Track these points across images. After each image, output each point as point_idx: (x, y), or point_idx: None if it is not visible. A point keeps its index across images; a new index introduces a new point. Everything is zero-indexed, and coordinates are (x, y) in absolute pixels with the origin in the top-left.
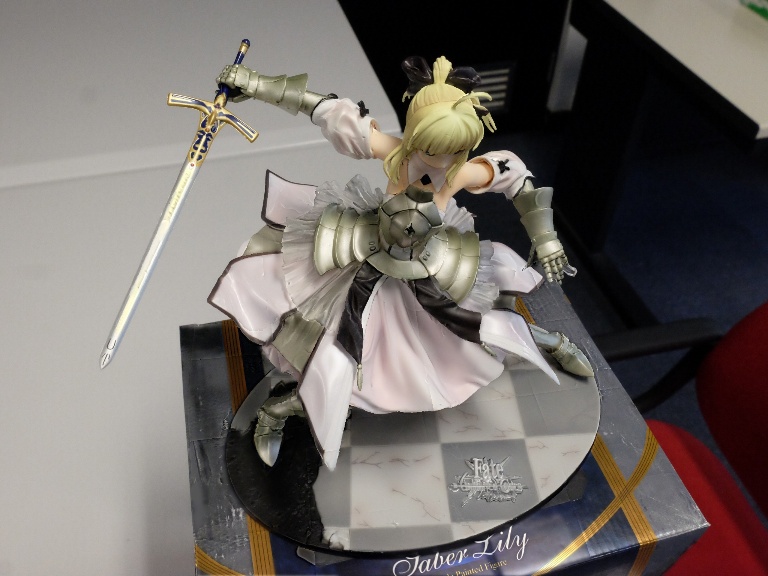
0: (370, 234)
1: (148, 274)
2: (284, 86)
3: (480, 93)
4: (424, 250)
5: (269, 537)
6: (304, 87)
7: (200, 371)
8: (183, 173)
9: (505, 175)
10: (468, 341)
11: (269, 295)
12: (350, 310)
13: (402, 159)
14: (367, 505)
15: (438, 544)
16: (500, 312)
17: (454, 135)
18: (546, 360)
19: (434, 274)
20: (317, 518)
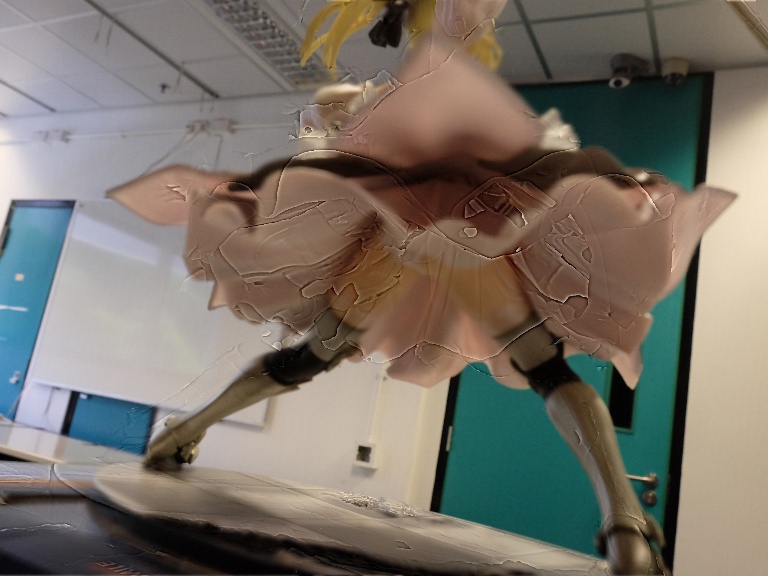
0: None
1: None
2: None
3: None
4: None
5: None
6: None
7: None
8: None
9: None
10: (386, 299)
11: None
12: None
13: None
14: None
15: None
16: None
17: None
18: None
19: None
20: None
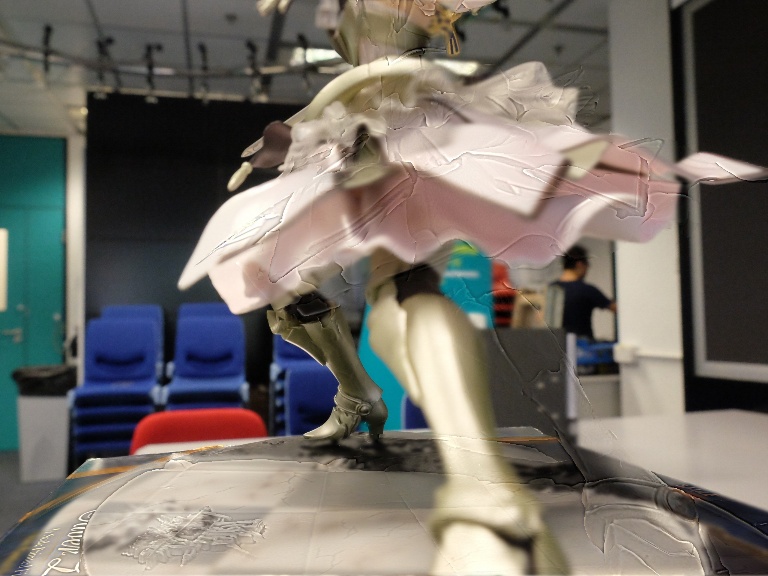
0: None
1: None
2: None
3: None
4: None
5: None
6: None
7: (461, 431)
8: None
9: None
10: None
11: None
12: None
13: None
14: (215, 477)
15: (101, 505)
16: None
17: None
18: (328, 242)
19: None
20: None
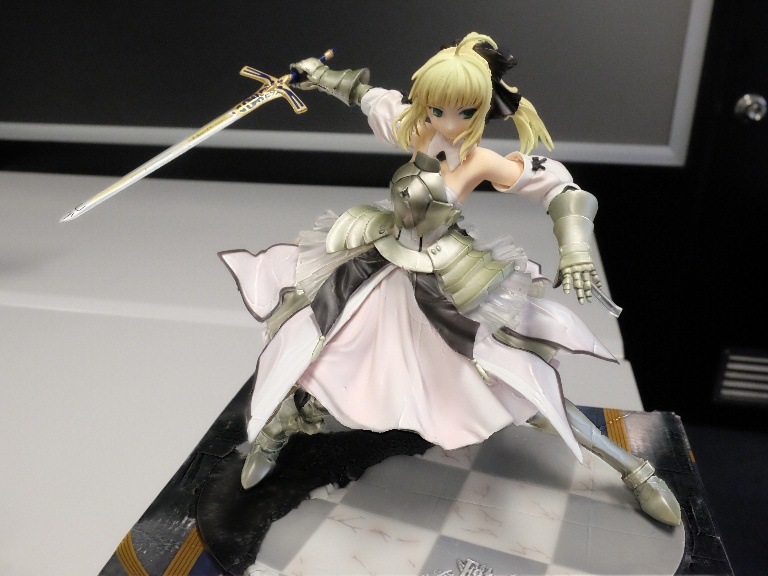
0: (386, 220)
1: (146, 172)
2: (343, 74)
3: (481, 35)
4: (435, 243)
5: (200, 554)
6: (357, 73)
7: (246, 404)
8: (222, 116)
9: (539, 175)
10: (470, 369)
11: (282, 273)
12: (335, 282)
13: (412, 120)
14: (315, 560)
15: None
16: (523, 352)
17: (450, 78)
18: None
19: (440, 271)
20: (256, 552)
